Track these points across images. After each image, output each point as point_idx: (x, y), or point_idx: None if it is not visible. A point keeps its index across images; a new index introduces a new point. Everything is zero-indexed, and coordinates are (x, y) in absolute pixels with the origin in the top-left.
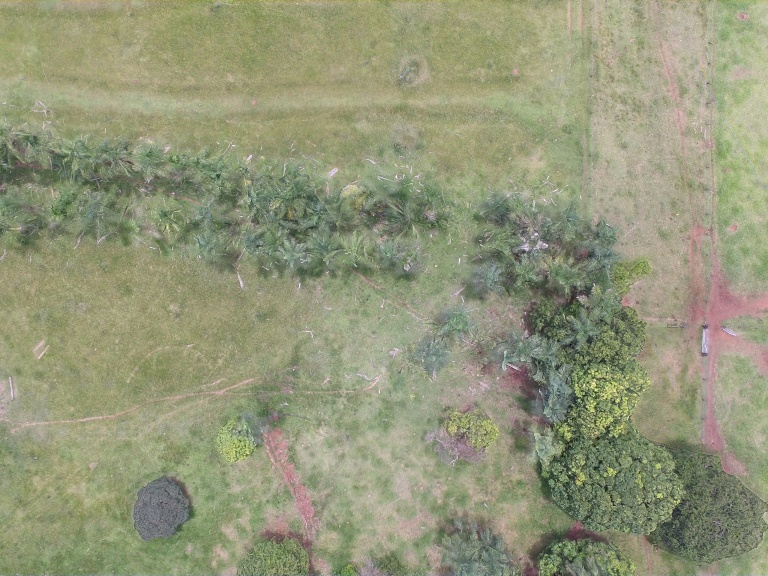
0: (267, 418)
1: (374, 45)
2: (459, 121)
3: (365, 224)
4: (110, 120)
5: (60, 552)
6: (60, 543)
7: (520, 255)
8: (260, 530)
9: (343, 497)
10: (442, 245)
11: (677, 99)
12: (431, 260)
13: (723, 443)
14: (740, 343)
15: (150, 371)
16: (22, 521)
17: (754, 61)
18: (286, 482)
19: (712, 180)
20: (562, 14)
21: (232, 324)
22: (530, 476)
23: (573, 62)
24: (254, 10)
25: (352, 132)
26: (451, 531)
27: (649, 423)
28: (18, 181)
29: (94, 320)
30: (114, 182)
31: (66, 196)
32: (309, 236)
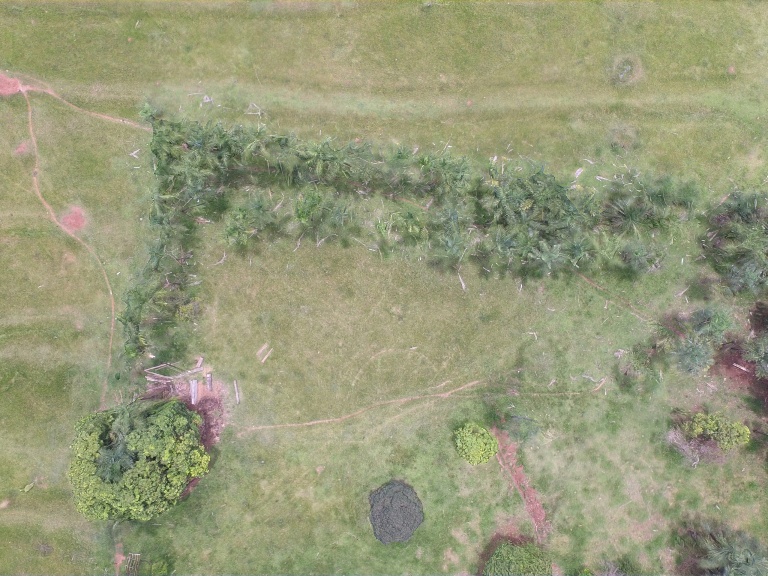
0: (494, 421)
1: (587, 44)
2: (676, 120)
3: (585, 224)
4: (324, 122)
5: (290, 556)
6: (290, 547)
7: None
8: (491, 533)
9: (573, 500)
10: None
11: None
12: None
13: None
14: None
15: (375, 374)
16: (251, 525)
17: None
18: (515, 485)
19: None
20: None
21: (455, 326)
22: (762, 478)
23: None
24: (465, 10)
25: (569, 132)
26: (684, 534)
27: None
28: (236, 184)
29: (316, 323)
30: (332, 184)
31: (311, 198)
32: (558, 237)
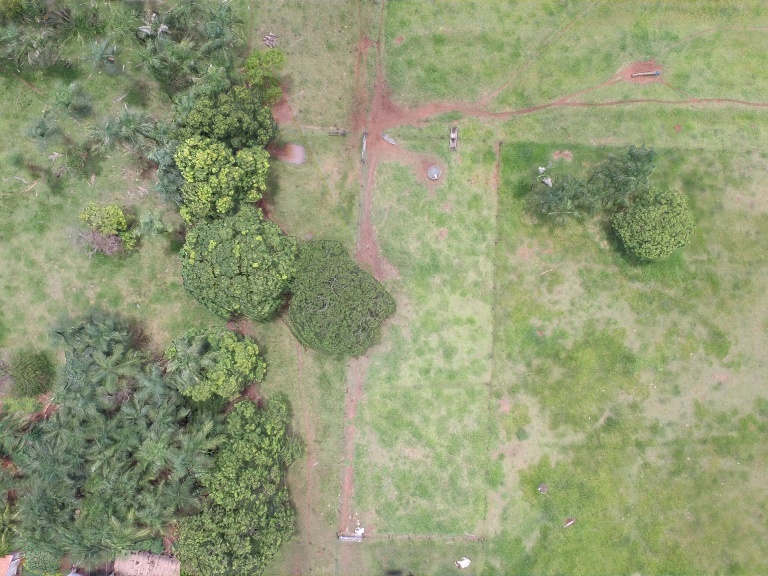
0: None
1: None
2: None
3: (30, 30)
4: None
5: None
6: None
7: (146, 40)
8: None
9: None
10: None
11: None
12: (95, 67)
13: (378, 248)
14: (400, 152)
15: None
16: None
17: None
18: None
19: None
20: None
21: None
22: None
23: None
24: None
25: None
26: None
27: (306, 228)
28: None
29: None
30: None
31: None
32: None
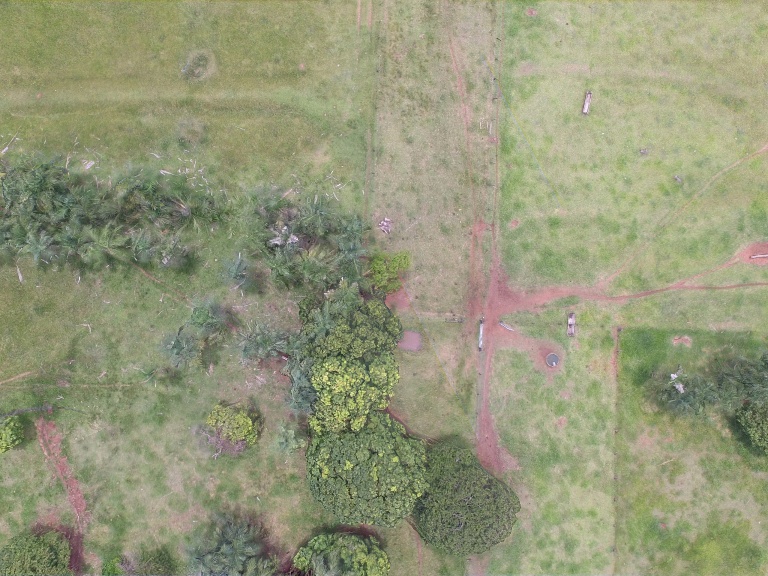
0: (41, 411)
1: (162, 39)
2: (245, 115)
3: (146, 218)
4: None
5: None
6: None
7: (275, 249)
8: (31, 523)
9: (115, 490)
10: (223, 239)
11: (464, 94)
12: (212, 254)
13: (497, 437)
14: (517, 338)
15: None
16: None
17: (542, 57)
18: (59, 475)
19: (496, 175)
20: (351, 9)
21: (10, 317)
22: (303, 470)
23: (360, 57)
24: (42, 3)
25: (137, 126)
26: (223, 525)
27: (424, 417)
28: None
29: None
30: None
31: None
32: (61, 229)
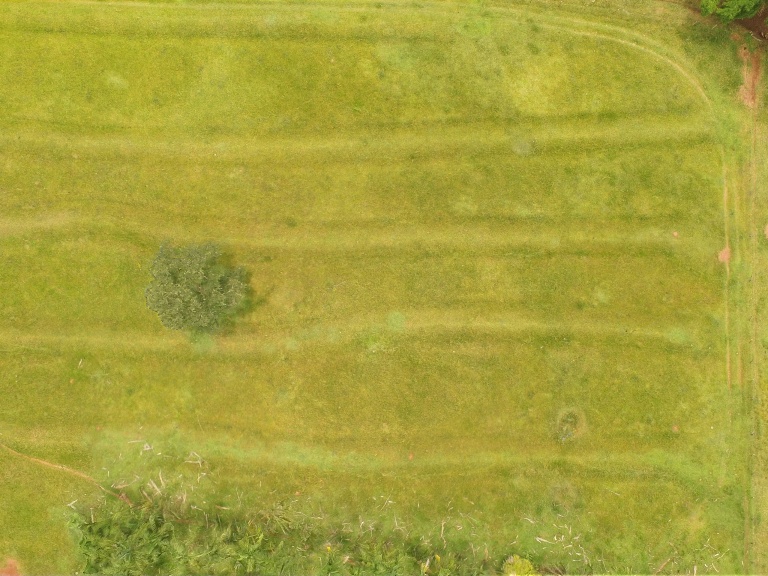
0: None
1: (531, 396)
2: (618, 478)
3: None
4: (265, 472)
5: None
6: None
7: None
8: None
9: None
10: None
11: None
12: None
13: None
14: None
15: None
16: None
17: None
18: None
19: None
20: (722, 367)
21: None
22: None
23: (733, 419)
24: (410, 358)
25: (510, 489)
26: None
27: None
28: None
29: None
30: (270, 540)
31: None
32: None
